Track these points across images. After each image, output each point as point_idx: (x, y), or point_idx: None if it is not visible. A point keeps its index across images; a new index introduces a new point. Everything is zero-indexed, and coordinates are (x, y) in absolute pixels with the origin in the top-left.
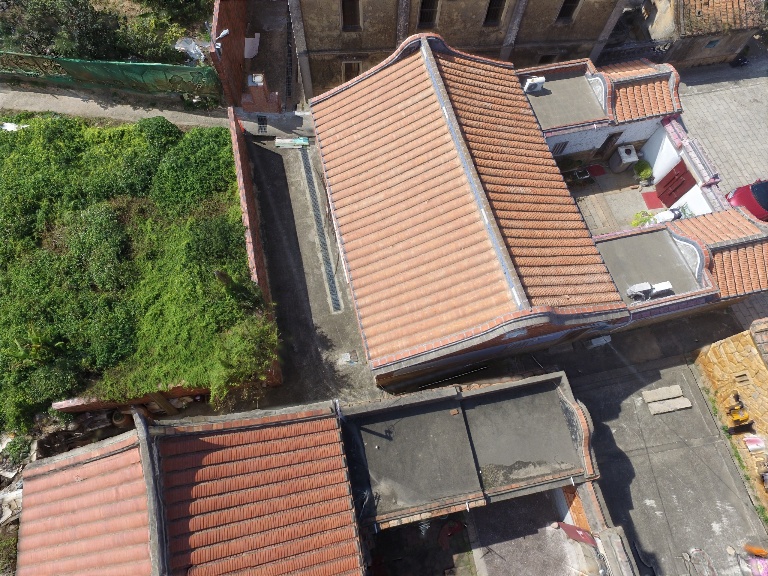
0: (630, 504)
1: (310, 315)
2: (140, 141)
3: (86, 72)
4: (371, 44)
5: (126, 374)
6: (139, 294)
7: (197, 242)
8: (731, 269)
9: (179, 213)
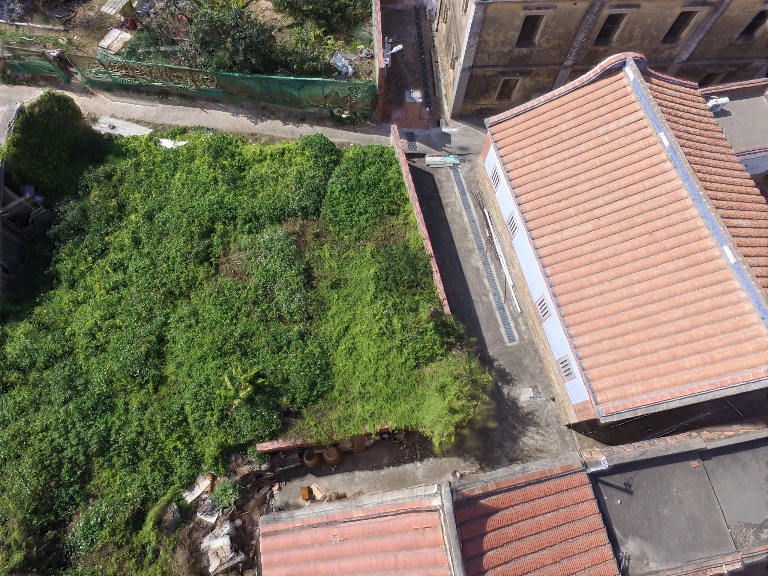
0: None
1: (485, 346)
2: (302, 160)
3: (241, 86)
4: (539, 60)
5: (326, 413)
6: (328, 326)
7: (385, 271)
8: None
9: (356, 238)
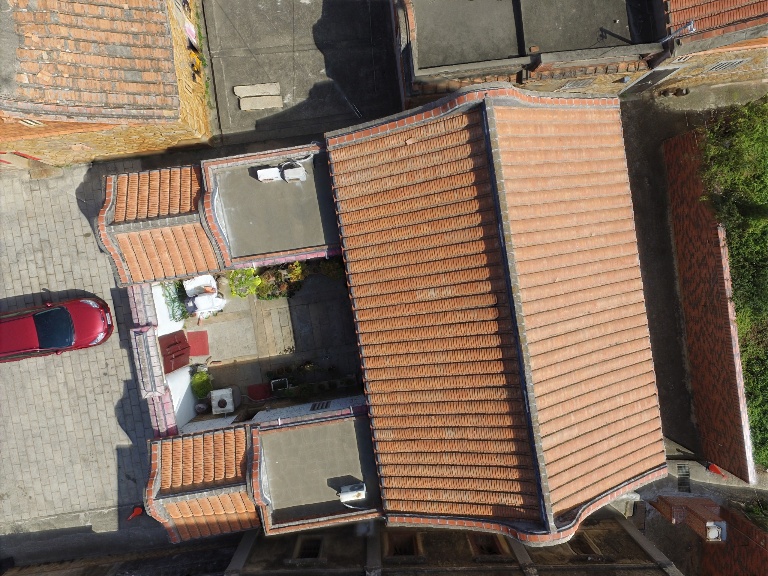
0: (326, 1)
1: None
2: None
3: None
4: (574, 575)
5: None
6: None
7: None
8: (172, 196)
9: None
